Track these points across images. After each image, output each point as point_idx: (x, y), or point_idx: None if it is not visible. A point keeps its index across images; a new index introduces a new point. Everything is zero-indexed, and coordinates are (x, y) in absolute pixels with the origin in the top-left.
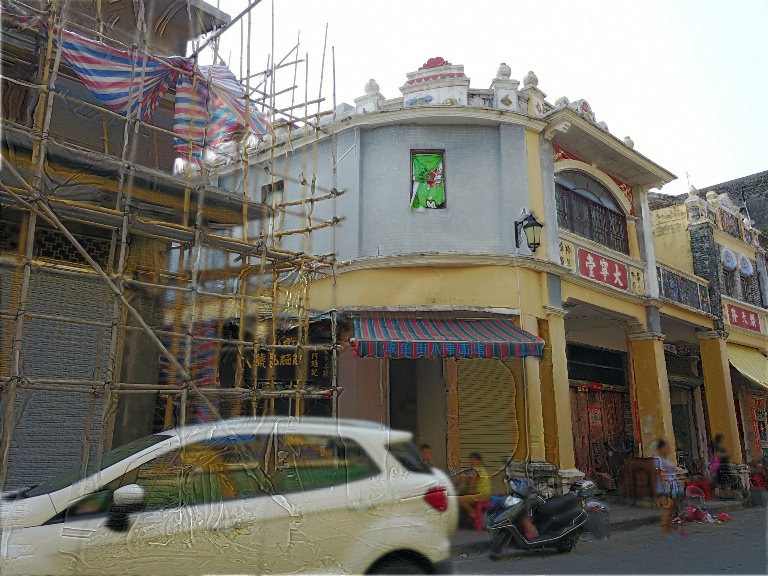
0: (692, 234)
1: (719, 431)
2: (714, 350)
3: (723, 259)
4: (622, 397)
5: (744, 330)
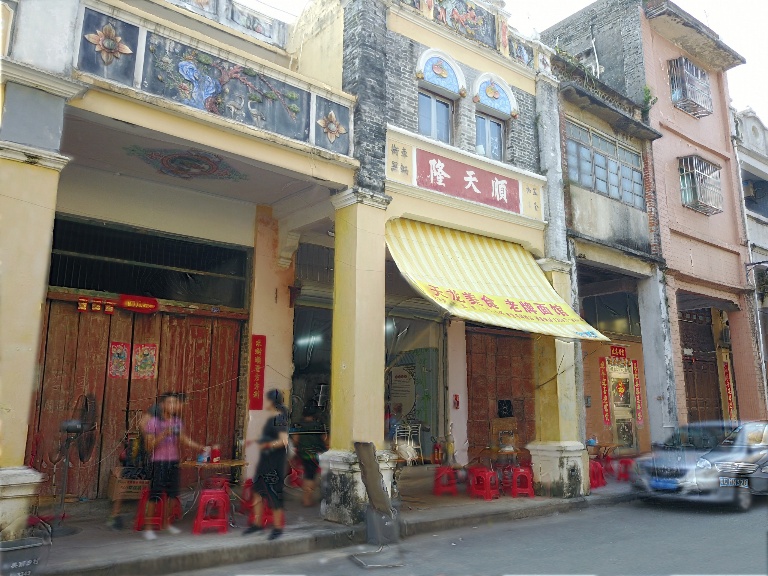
0: (345, 14)
1: (340, 385)
2: (349, 227)
3: (419, 67)
4: (241, 328)
5: (460, 201)
